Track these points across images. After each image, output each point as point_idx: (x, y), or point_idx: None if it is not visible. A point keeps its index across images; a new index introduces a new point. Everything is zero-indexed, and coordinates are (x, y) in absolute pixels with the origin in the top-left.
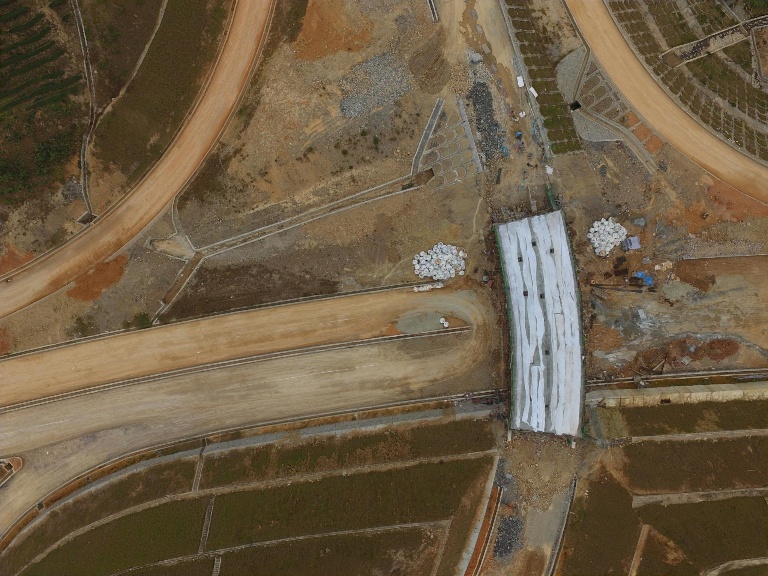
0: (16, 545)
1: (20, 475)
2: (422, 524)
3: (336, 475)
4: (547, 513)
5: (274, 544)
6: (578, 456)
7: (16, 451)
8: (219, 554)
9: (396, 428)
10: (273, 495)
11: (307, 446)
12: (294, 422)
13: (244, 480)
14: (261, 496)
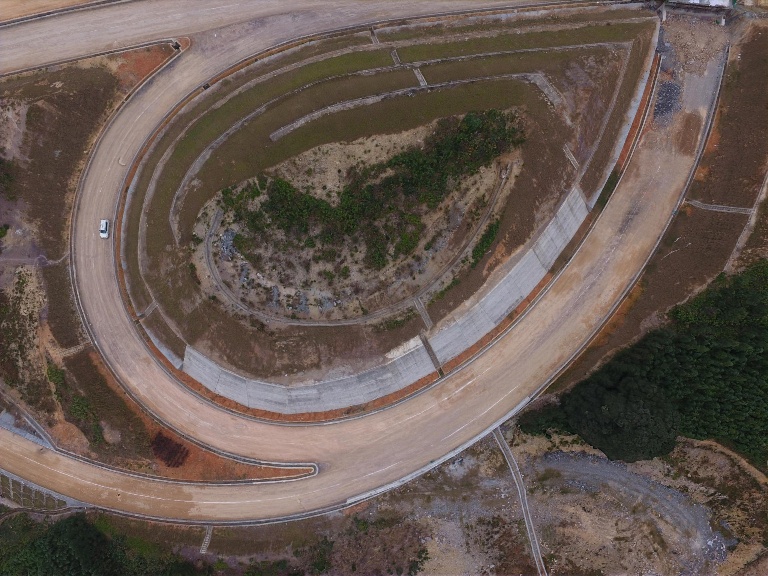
0: (186, 112)
1: (186, 56)
2: (607, 43)
3: (511, 33)
4: (703, 78)
5: (468, 59)
6: (727, 33)
7: (183, 33)
8: (416, 66)
9: (557, 14)
10: (454, 44)
11: (475, 25)
12: (457, 15)
13: (423, 36)
14: (442, 45)
